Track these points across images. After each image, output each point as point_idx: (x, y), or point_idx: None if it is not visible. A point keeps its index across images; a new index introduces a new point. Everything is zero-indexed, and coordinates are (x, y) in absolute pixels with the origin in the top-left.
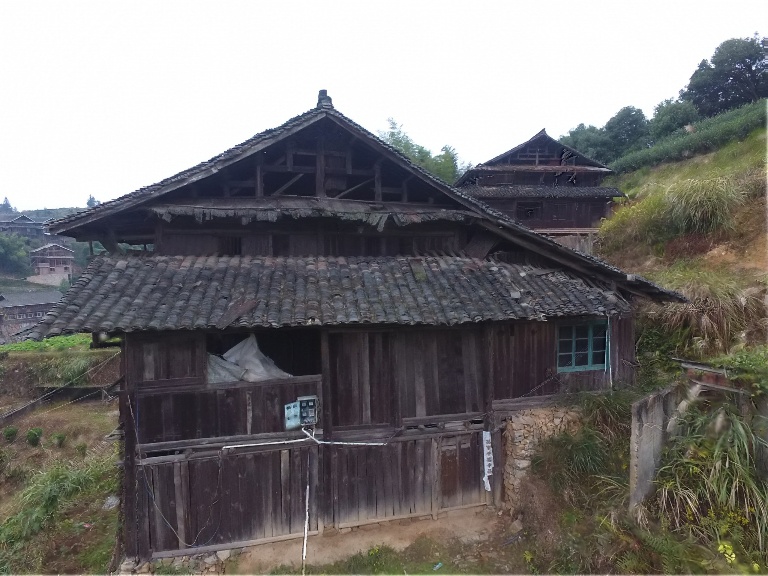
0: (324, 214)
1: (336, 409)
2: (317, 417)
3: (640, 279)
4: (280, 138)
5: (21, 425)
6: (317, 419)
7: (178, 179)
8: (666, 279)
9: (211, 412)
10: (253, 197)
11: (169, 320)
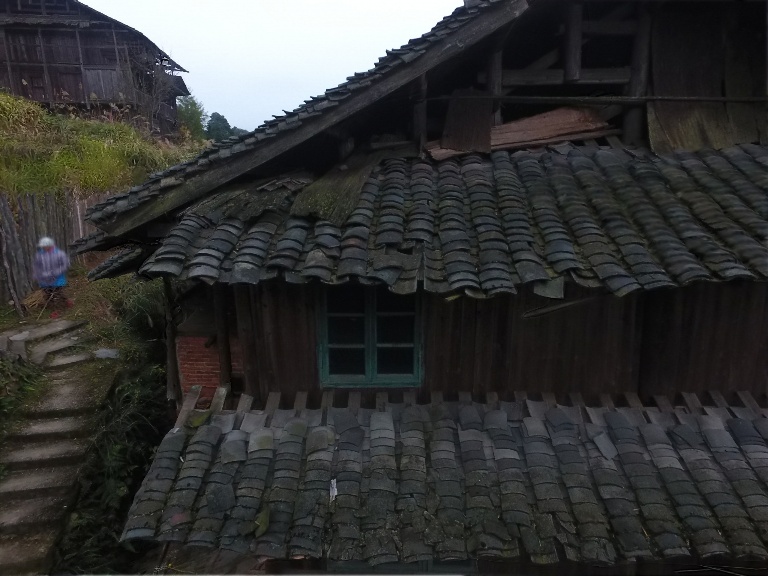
0: None
1: None
2: None
3: None
4: None
5: None
6: None
7: None
8: None
9: None
10: None
11: None
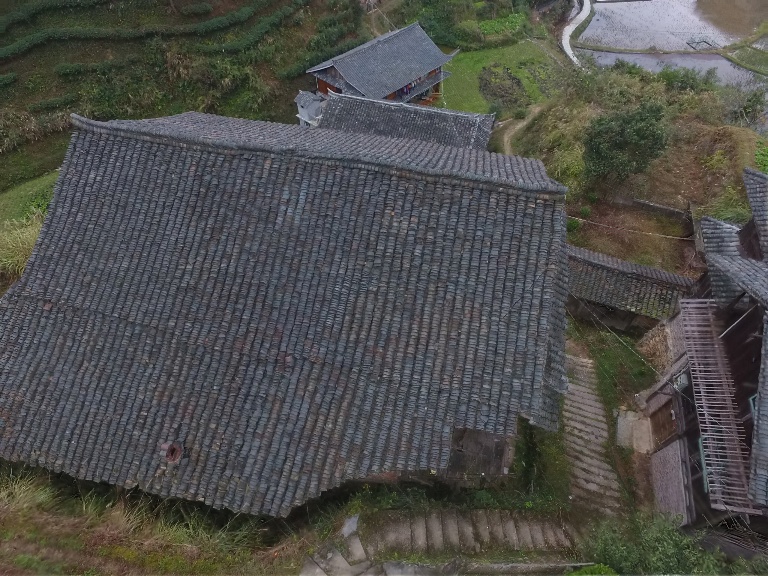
0: None
1: None
2: None
3: None
4: None
5: (617, 216)
6: None
7: None
8: None
9: None
10: None
11: None
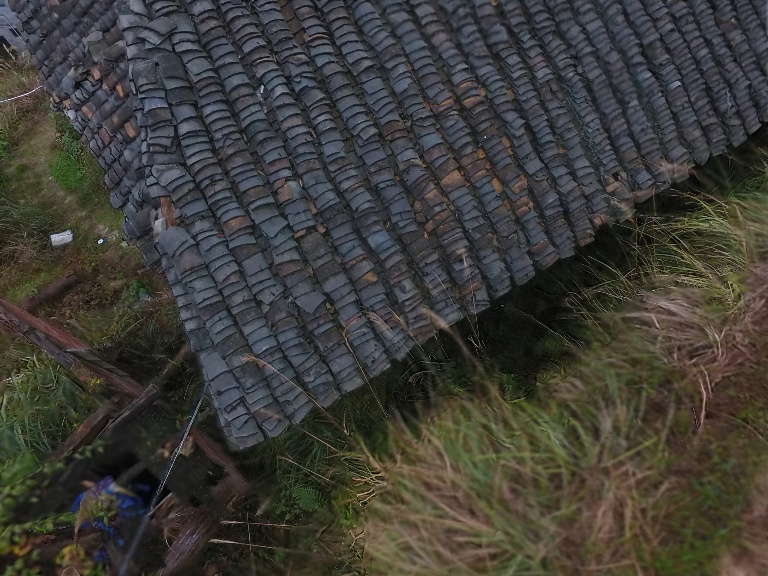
0: None
1: None
2: None
3: None
4: None
5: None
6: None
7: None
8: (543, 434)
9: None
10: None
11: None
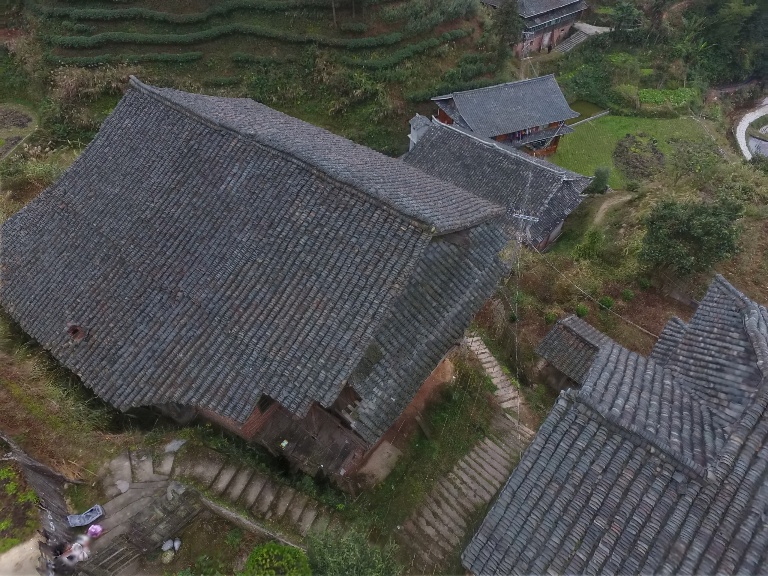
0: None
1: None
2: None
3: None
4: None
5: None
6: None
7: None
8: None
9: None
10: None
11: None
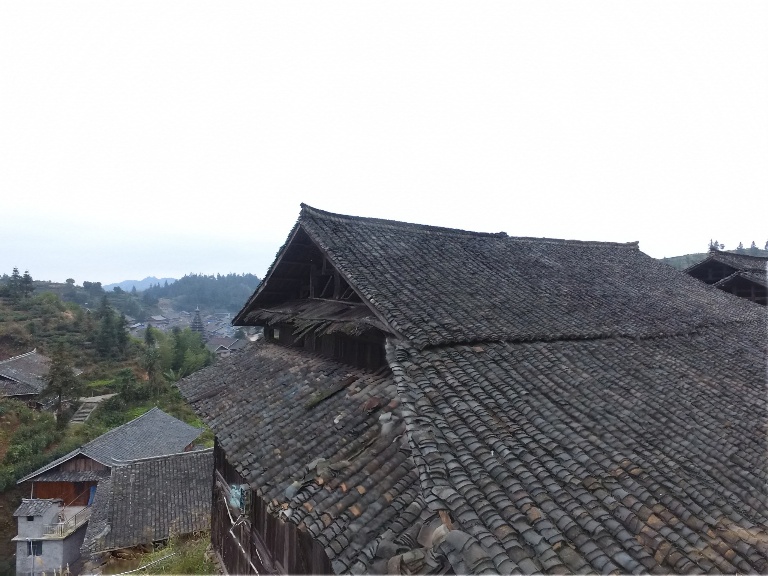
0: (286, 320)
1: (256, 511)
2: (245, 509)
3: (449, 556)
4: (284, 253)
5: None
6: (245, 511)
7: (254, 292)
8: None
9: (229, 466)
10: (305, 299)
11: (191, 391)
